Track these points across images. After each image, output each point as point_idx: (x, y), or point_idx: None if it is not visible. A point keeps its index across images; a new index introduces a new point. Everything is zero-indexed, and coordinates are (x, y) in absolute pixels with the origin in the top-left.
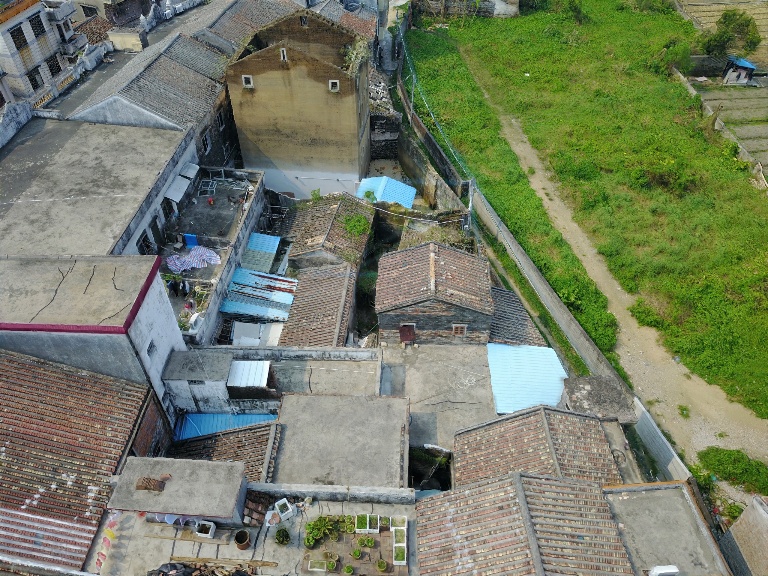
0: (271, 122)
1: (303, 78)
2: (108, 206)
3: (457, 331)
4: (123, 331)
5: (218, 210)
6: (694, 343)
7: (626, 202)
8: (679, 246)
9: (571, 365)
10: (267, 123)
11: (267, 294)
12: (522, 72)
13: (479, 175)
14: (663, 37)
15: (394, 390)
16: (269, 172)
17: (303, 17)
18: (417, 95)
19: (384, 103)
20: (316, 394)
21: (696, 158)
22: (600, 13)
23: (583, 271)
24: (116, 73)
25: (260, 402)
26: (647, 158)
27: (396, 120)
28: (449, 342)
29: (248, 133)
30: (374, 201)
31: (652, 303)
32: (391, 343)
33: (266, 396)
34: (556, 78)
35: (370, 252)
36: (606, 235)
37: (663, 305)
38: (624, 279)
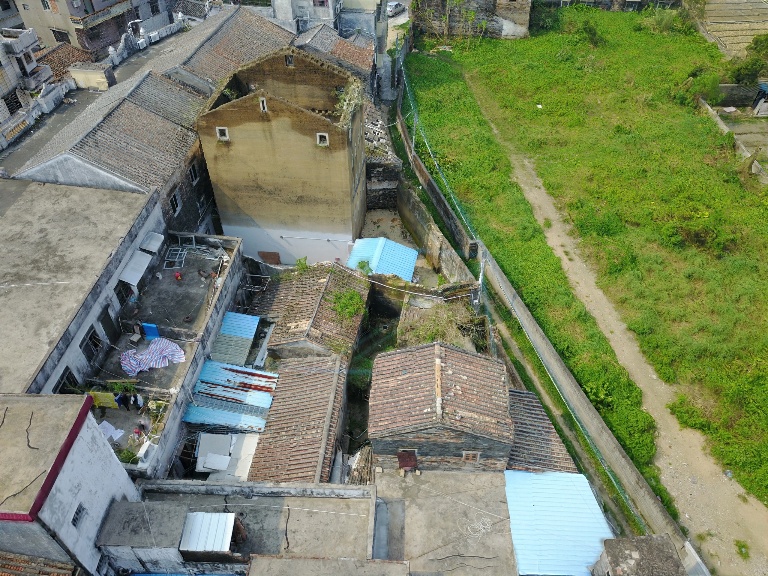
0: (251, 178)
1: (286, 131)
2: (47, 297)
3: (468, 457)
4: (29, 519)
5: (186, 287)
6: (749, 455)
7: (658, 265)
8: (722, 323)
9: (603, 483)
10: (246, 179)
11: (241, 395)
12: (534, 103)
13: (489, 230)
14: (687, 63)
15: (391, 537)
16: (250, 230)
17: (288, 56)
18: (419, 131)
19: (382, 145)
20: (292, 557)
21: (732, 208)
22: (616, 34)
23: (612, 355)
24: (76, 118)
25: (223, 564)
26: (678, 210)
27: (395, 167)
28: (458, 468)
29: (225, 189)
30: (369, 273)
31: (696, 400)
32: (388, 468)
33: (230, 560)
34: (572, 111)
35: (364, 332)
36: (637, 308)
37: (709, 403)
38: (660, 364)
